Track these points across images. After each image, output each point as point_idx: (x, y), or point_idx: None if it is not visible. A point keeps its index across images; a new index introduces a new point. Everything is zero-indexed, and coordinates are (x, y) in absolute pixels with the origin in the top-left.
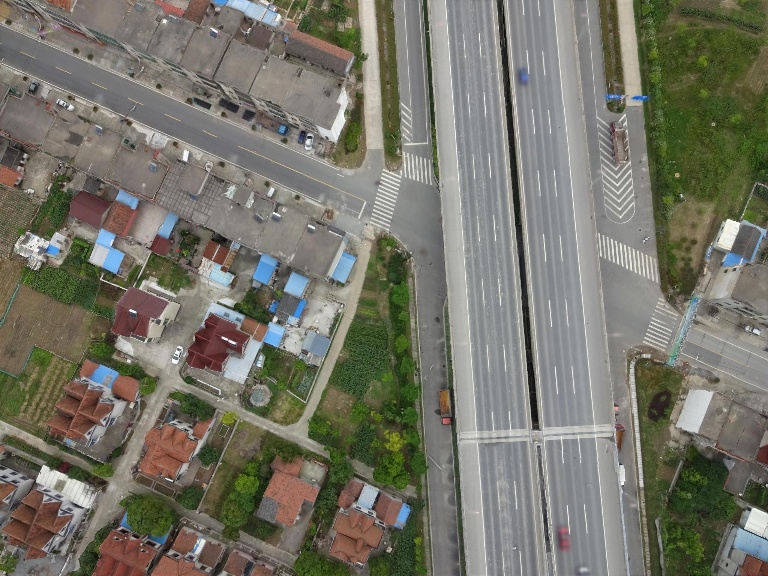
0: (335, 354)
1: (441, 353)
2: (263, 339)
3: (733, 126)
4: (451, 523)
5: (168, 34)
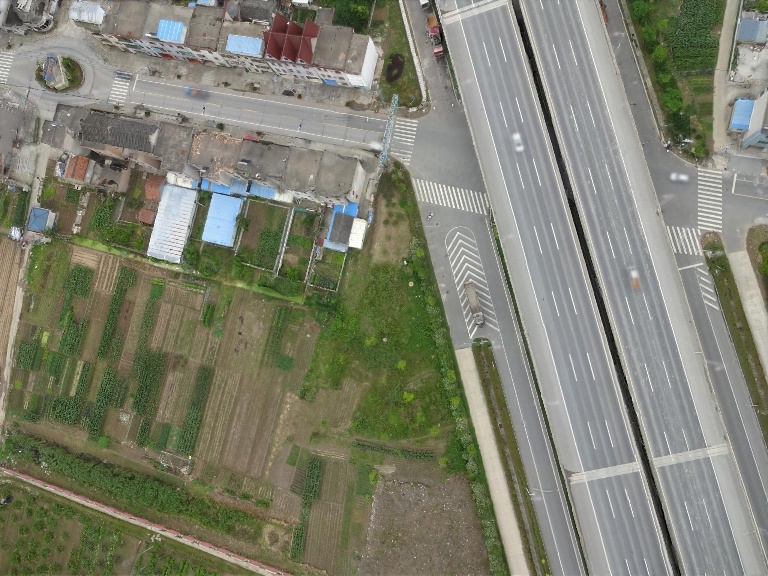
0: (726, 31)
1: None
2: None
3: None
4: None
5: None
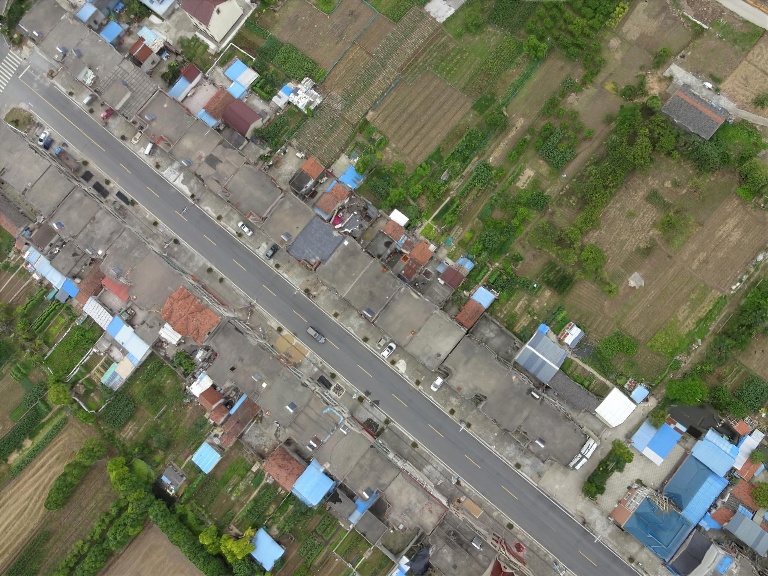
0: None
1: None
2: None
3: None
4: None
5: (101, 239)
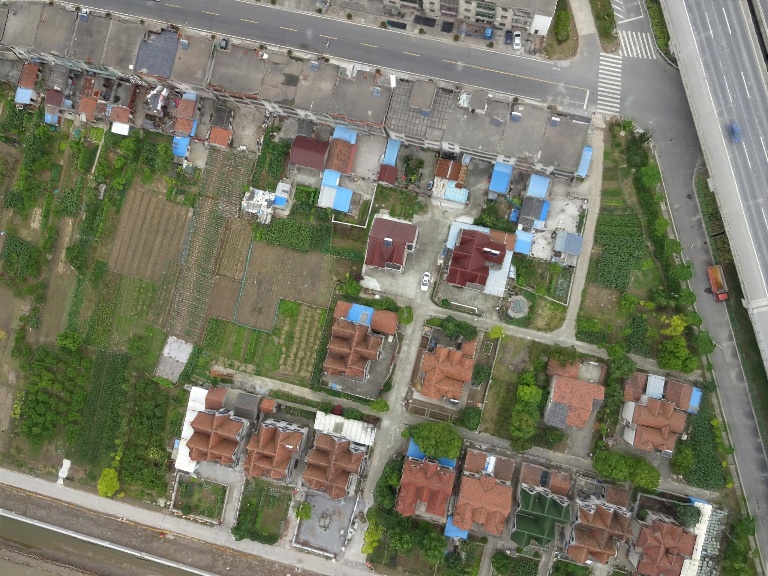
0: (587, 252)
1: (700, 230)
2: (514, 248)
3: None
4: (744, 400)
5: None
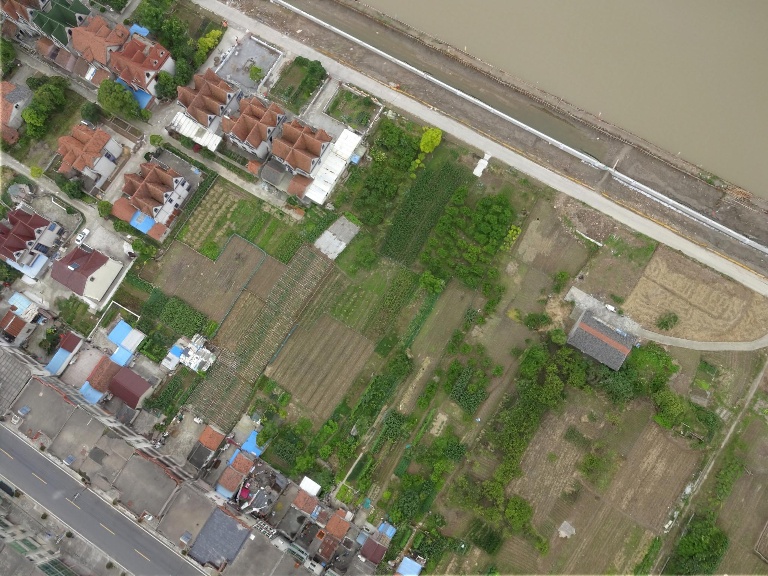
0: None
1: None
2: None
3: None
4: None
5: None
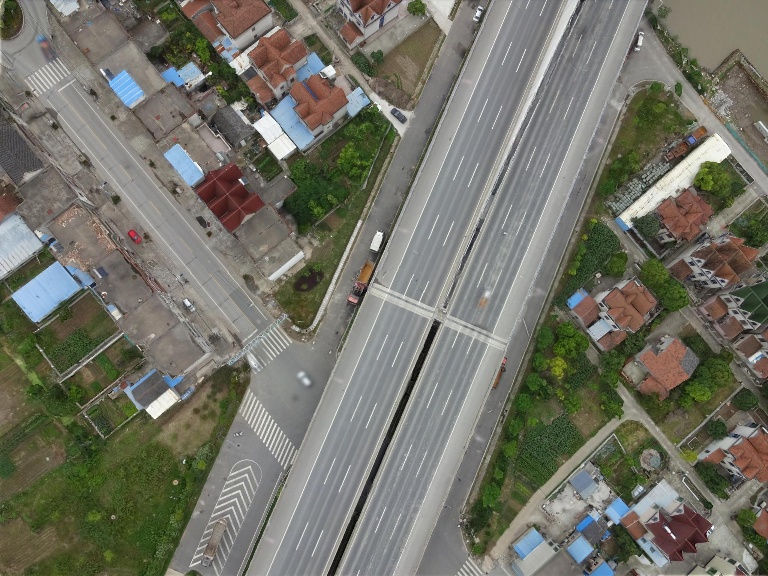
0: (569, 465)
1: None
2: (630, 512)
3: (96, 507)
4: None
5: None
